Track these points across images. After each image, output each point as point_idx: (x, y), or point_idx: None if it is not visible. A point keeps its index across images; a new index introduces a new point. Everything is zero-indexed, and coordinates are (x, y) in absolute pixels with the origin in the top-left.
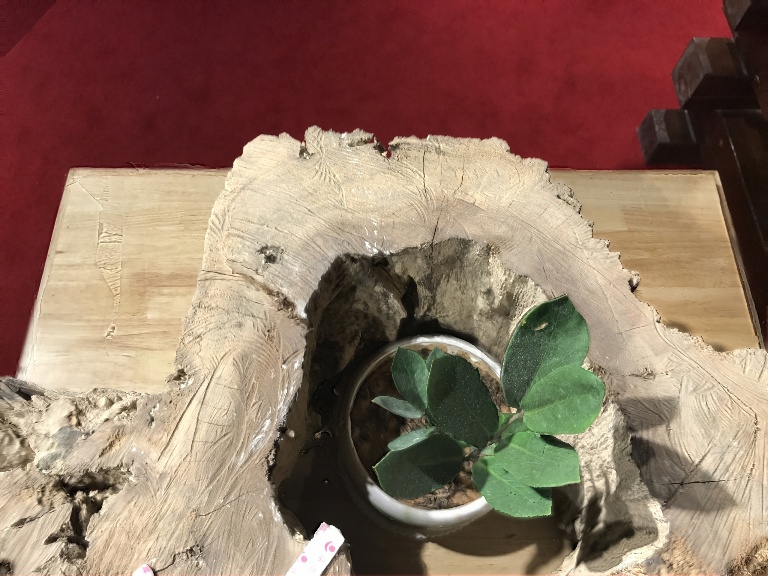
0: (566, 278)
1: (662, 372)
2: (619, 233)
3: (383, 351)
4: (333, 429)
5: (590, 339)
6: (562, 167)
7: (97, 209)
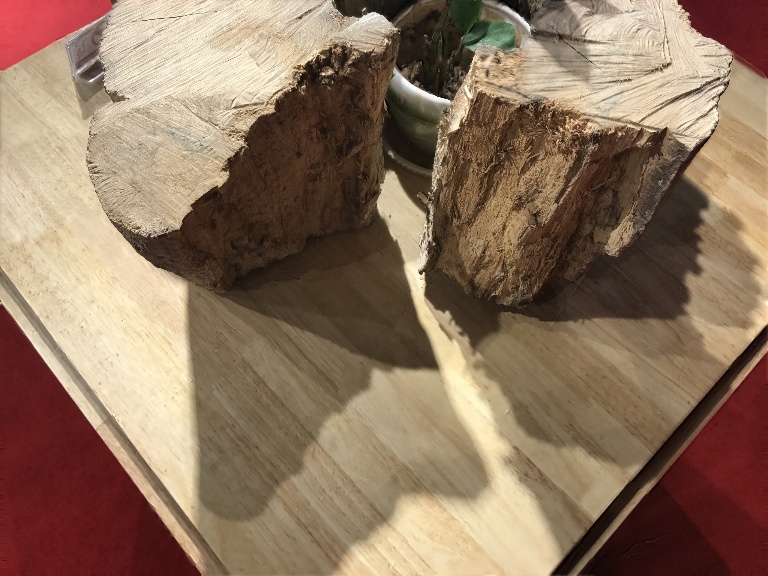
0: None
1: None
2: (757, 135)
3: None
4: None
5: None
6: (759, 68)
7: None
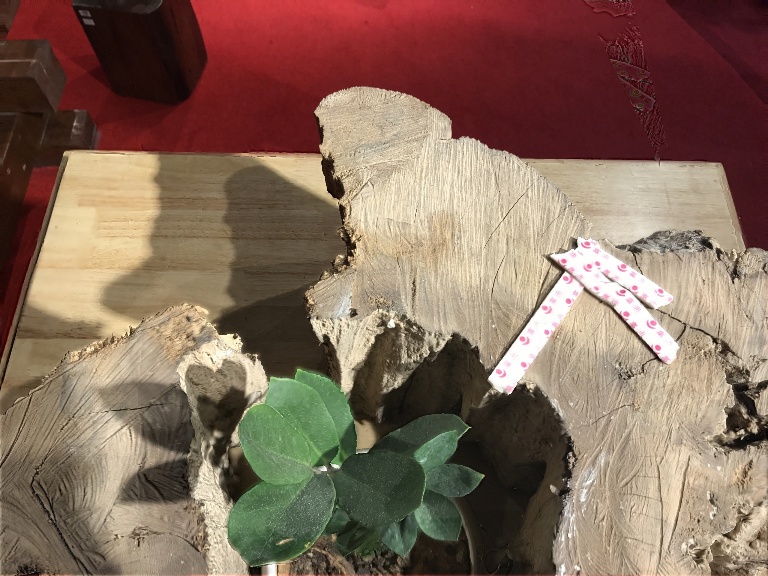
0: None
1: (122, 538)
2: None
3: None
4: (484, 567)
5: None
6: None
7: None
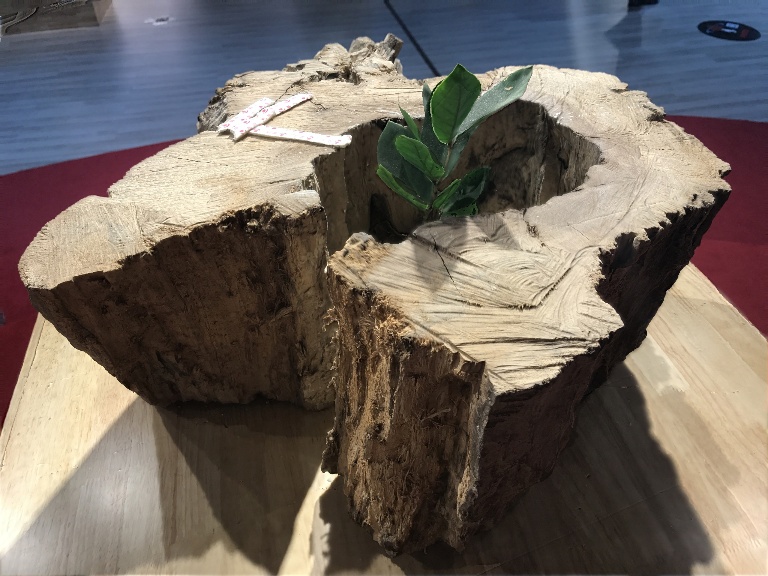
0: (604, 195)
1: None
2: None
3: None
4: None
5: (550, 208)
6: None
7: None
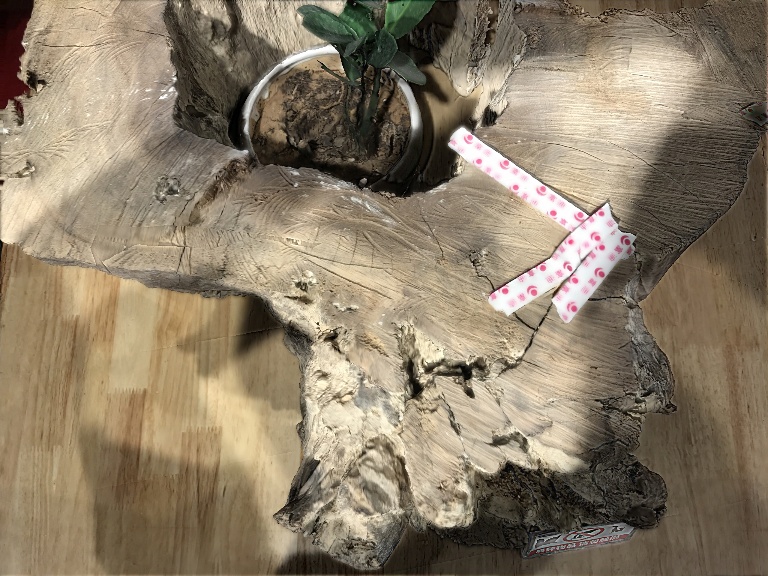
0: None
1: None
2: None
3: None
4: None
5: None
6: None
7: (13, 567)
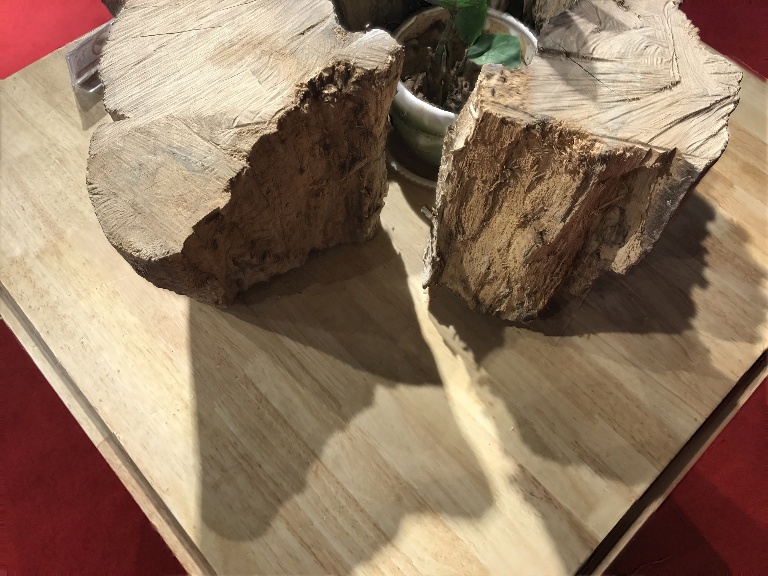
0: None
1: None
2: (764, 145)
3: (478, 4)
4: None
5: None
6: (766, 77)
7: None
